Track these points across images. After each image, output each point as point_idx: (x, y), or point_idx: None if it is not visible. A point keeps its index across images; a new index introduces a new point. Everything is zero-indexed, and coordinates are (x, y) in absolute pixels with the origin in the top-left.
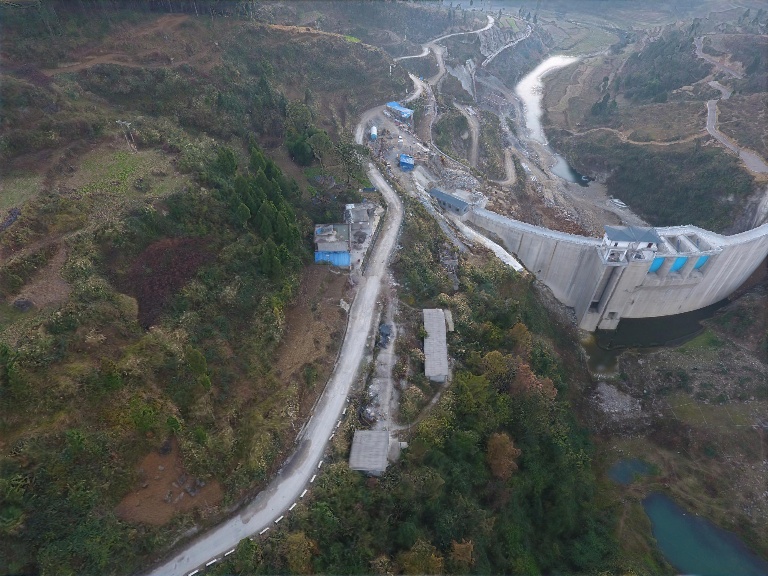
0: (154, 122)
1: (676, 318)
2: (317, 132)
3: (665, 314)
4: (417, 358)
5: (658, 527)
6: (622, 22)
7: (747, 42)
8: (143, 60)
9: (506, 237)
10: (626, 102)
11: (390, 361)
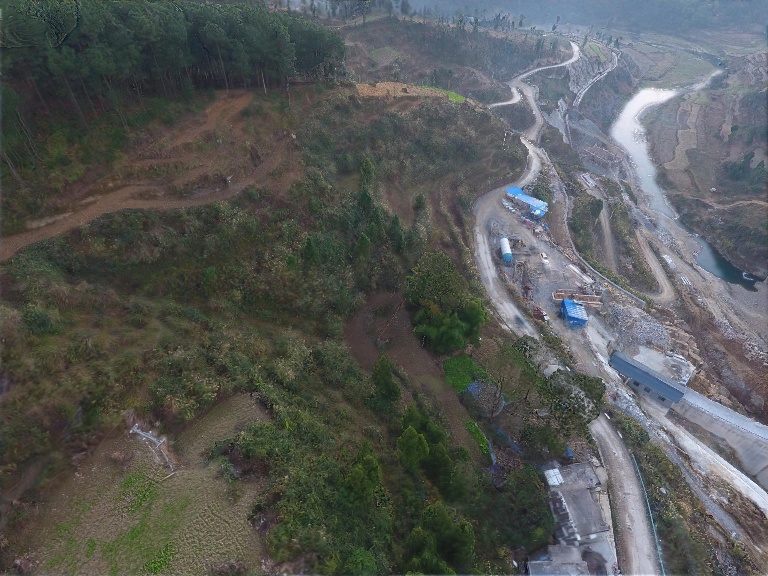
0: (203, 330)
1: None
2: (471, 307)
3: None
4: None
5: None
6: (710, 45)
7: None
8: (183, 191)
9: (744, 449)
10: None
11: None
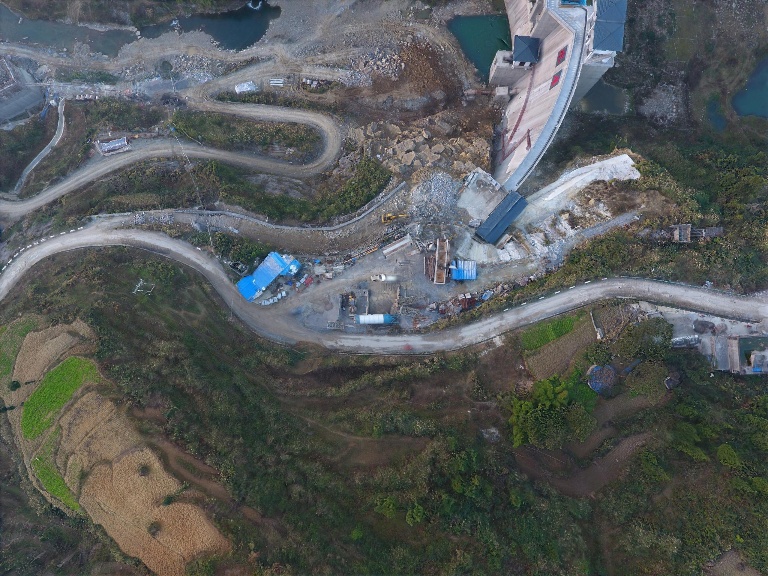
0: None
1: None
2: None
3: None
4: None
5: (754, 111)
6: None
7: None
8: None
9: None
10: None
11: None
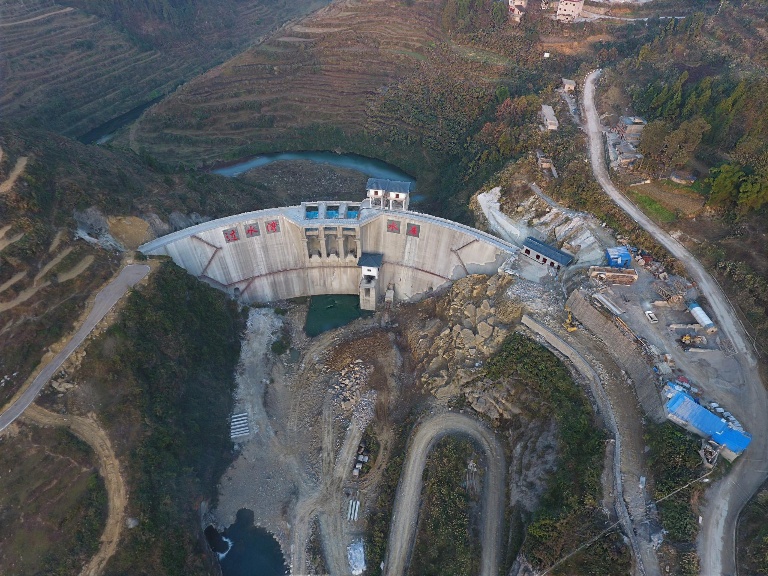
0: None
1: None
2: None
3: None
4: None
5: None
6: None
7: None
8: None
9: None
10: None
11: (570, 106)
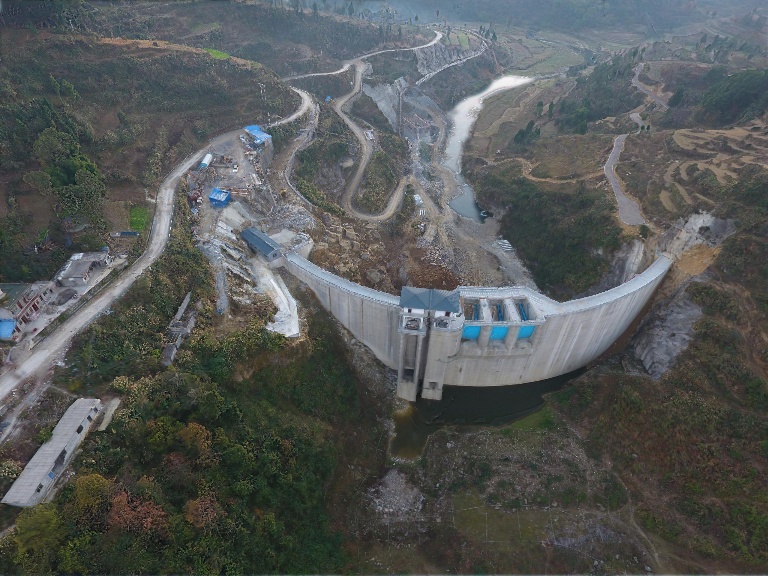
0: None
1: (520, 388)
2: (74, 165)
3: (505, 384)
4: (1, 476)
5: None
6: (593, 42)
7: (681, 71)
8: None
9: (316, 289)
10: (554, 130)
11: None
